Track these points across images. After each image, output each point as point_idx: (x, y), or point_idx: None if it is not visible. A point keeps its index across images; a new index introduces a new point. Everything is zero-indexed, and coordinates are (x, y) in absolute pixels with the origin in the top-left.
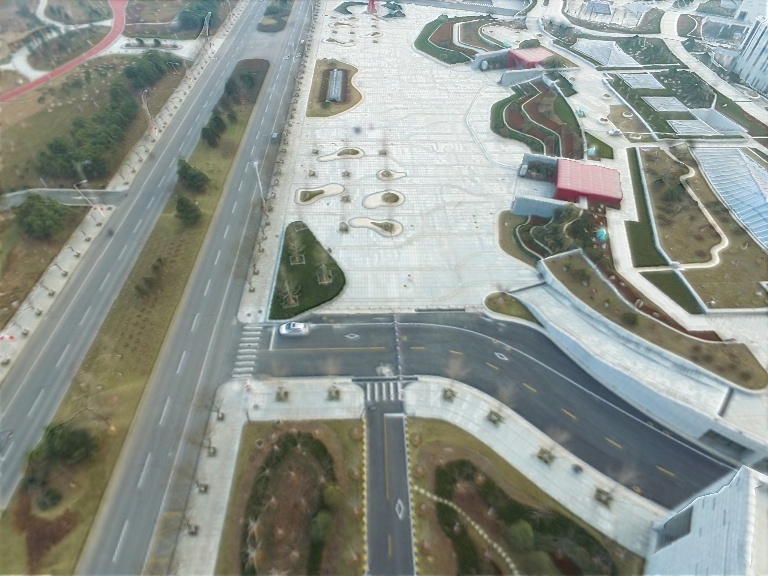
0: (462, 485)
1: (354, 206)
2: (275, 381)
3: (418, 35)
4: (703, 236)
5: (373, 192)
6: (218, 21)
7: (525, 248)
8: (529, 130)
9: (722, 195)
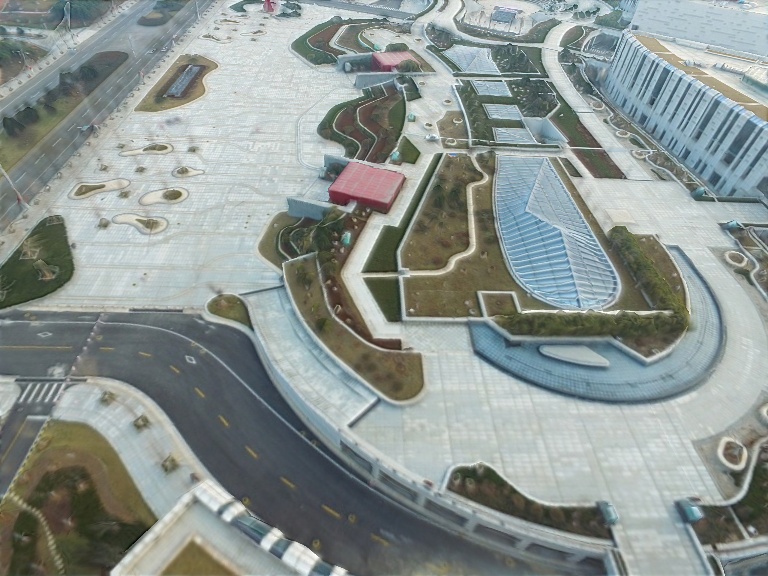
0: (59, 492)
1: (129, 202)
2: None
3: (302, 35)
4: (452, 243)
5: (158, 189)
6: (95, 12)
7: (279, 250)
8: (351, 132)
9: (497, 203)
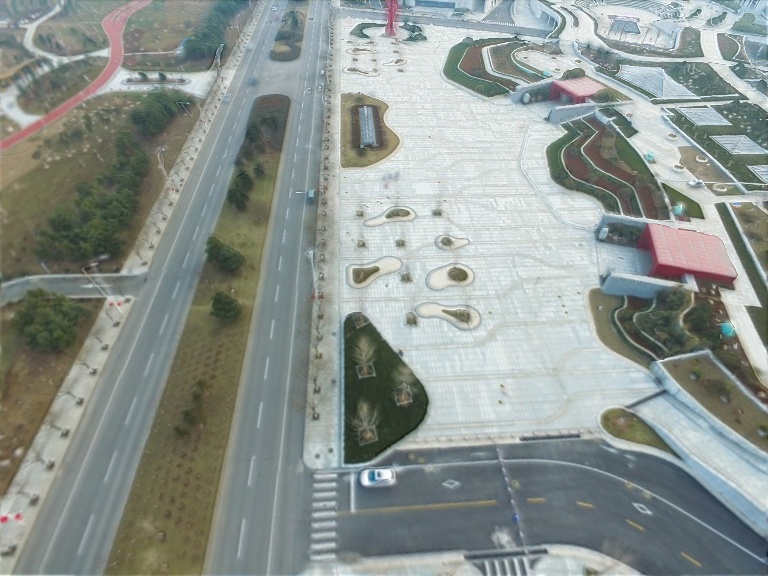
0: None
1: (417, 287)
2: (367, 564)
3: (445, 61)
4: None
5: (436, 267)
6: (227, 50)
7: (631, 342)
8: (597, 181)
9: None
